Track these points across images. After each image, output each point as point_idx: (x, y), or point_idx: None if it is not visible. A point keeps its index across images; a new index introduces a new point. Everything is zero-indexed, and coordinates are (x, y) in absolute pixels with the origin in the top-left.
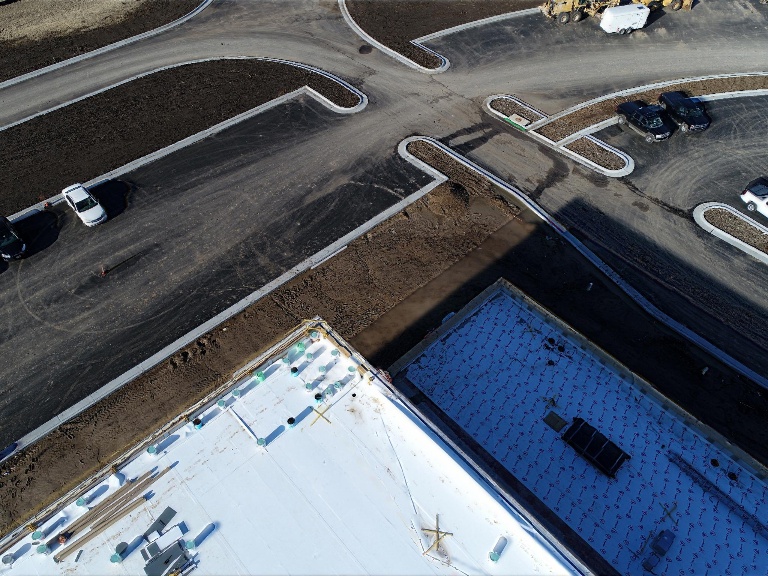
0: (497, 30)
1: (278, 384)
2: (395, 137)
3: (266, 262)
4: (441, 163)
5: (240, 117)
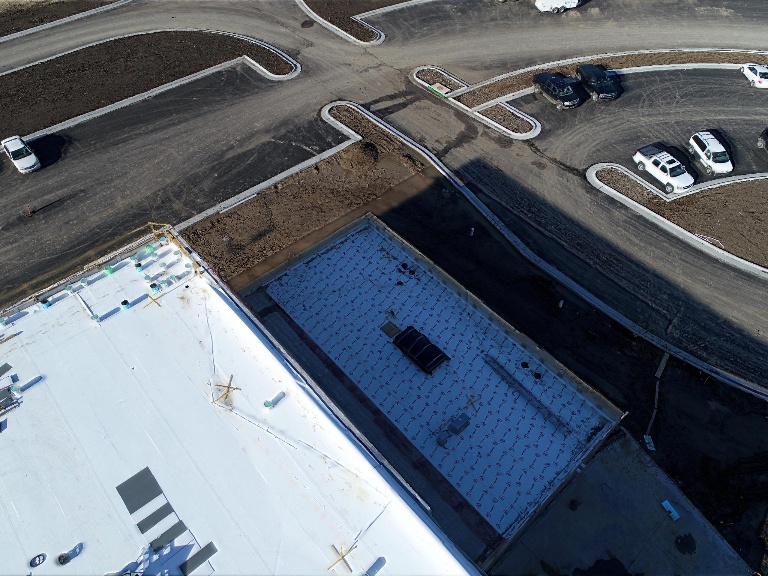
0: (436, 8)
1: (123, 277)
2: (320, 102)
3: (180, 207)
4: (359, 125)
5: (178, 82)
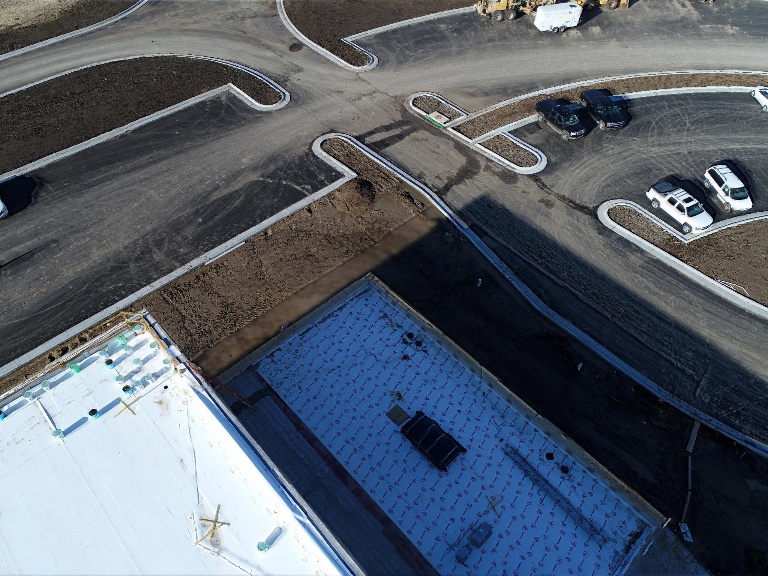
0: (431, 28)
1: (92, 376)
2: (311, 134)
3: (161, 258)
4: (353, 160)
5: (159, 114)
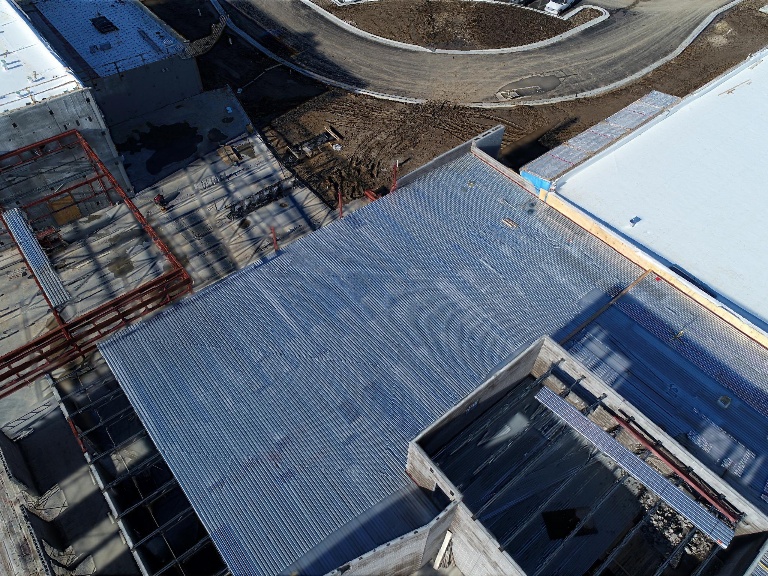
0: None
1: None
2: None
3: None
4: None
5: None
